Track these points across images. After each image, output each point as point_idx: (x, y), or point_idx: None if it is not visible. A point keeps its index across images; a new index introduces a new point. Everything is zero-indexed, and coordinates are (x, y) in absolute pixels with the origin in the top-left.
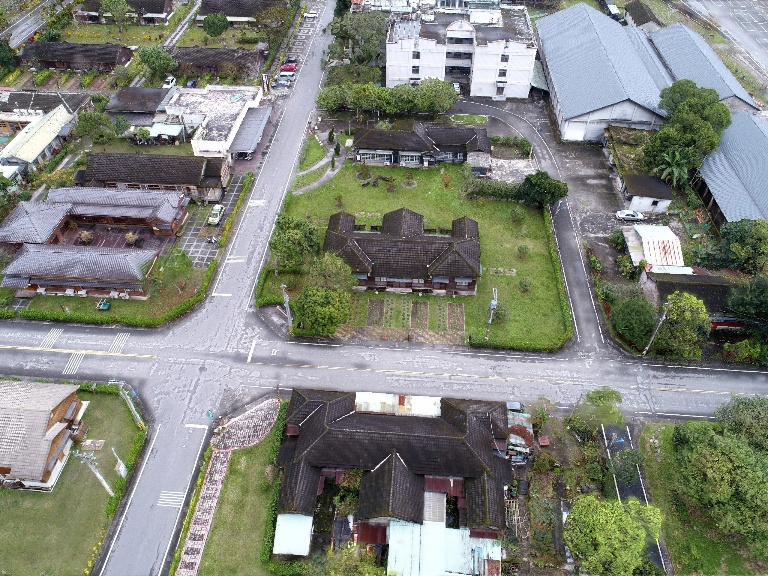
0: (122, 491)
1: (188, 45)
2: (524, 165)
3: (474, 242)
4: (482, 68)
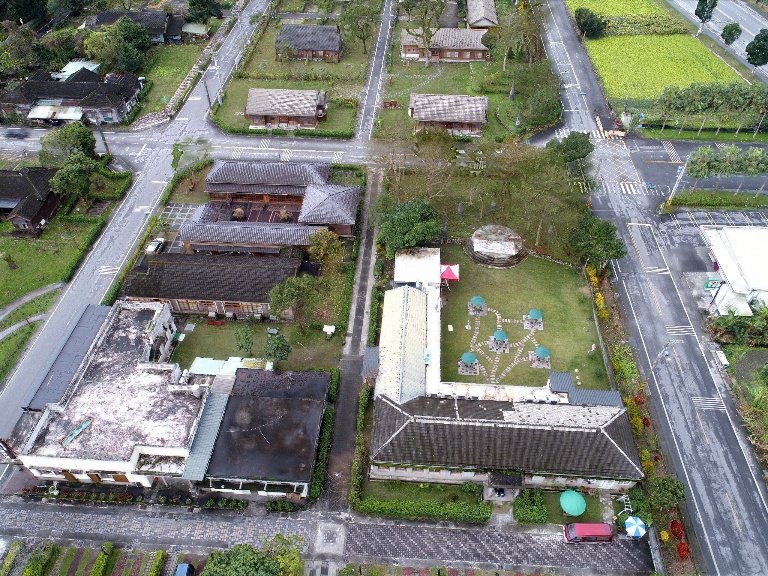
0: None
1: None
2: None
3: None
4: None
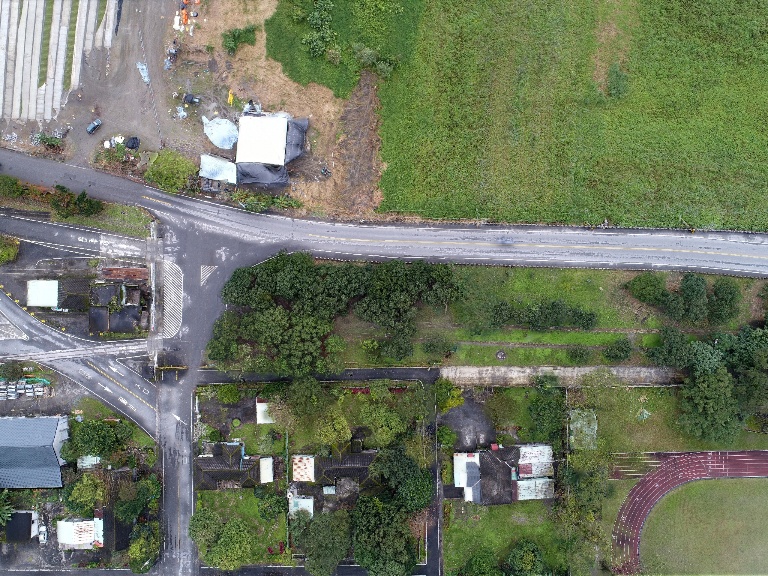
0: None
1: None
2: None
3: None
4: None
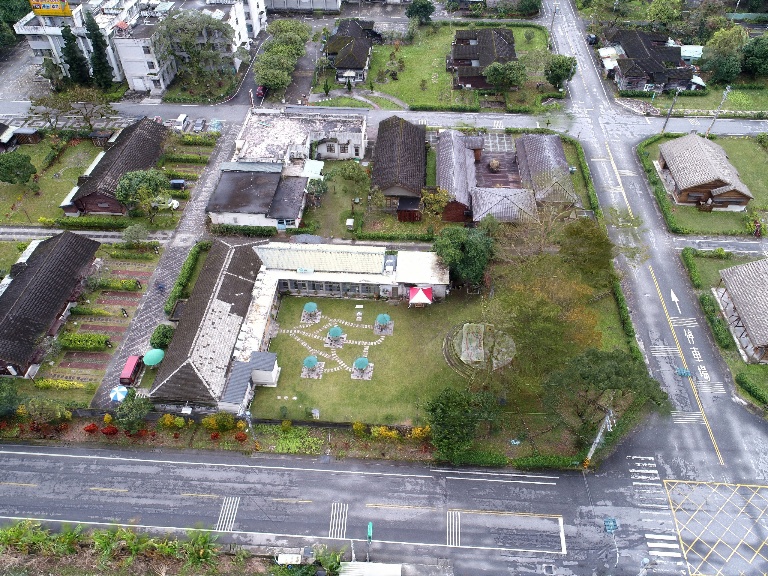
0: None
1: None
2: None
3: None
4: (253, 9)
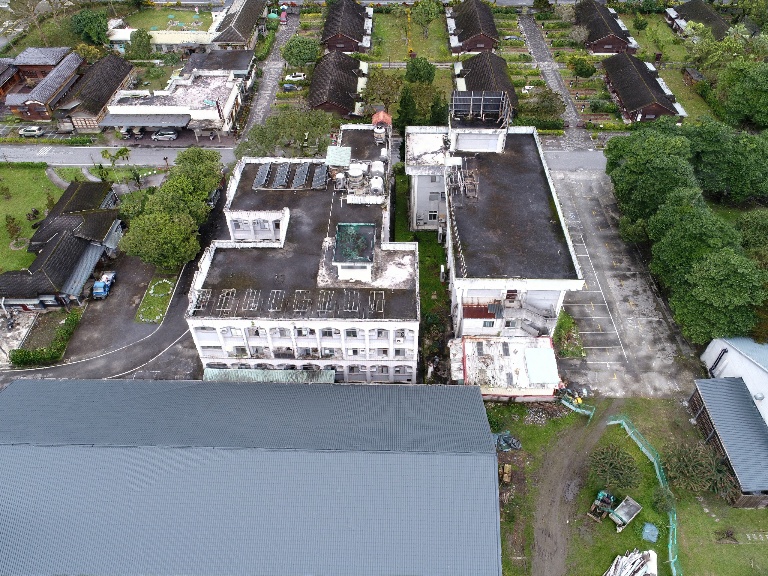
0: None
1: (400, 74)
2: None
3: None
4: None
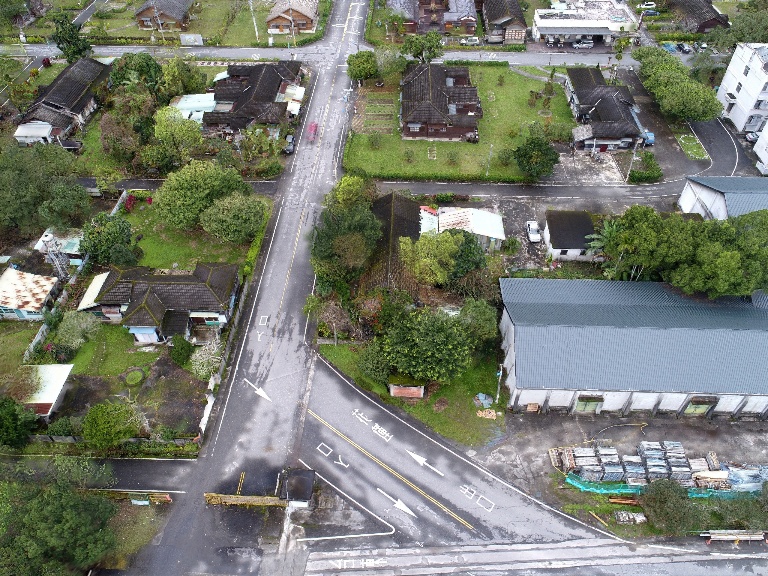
0: (262, 46)
1: (730, 5)
2: (611, 176)
3: (442, 118)
4: None
